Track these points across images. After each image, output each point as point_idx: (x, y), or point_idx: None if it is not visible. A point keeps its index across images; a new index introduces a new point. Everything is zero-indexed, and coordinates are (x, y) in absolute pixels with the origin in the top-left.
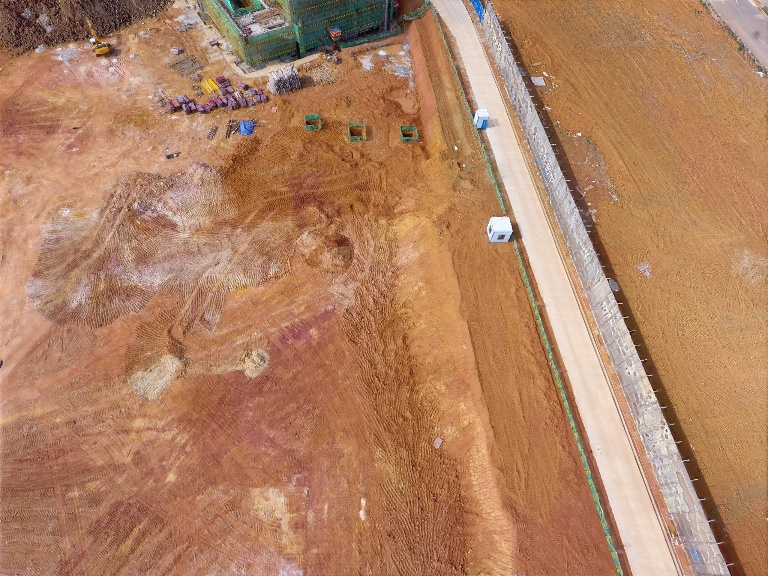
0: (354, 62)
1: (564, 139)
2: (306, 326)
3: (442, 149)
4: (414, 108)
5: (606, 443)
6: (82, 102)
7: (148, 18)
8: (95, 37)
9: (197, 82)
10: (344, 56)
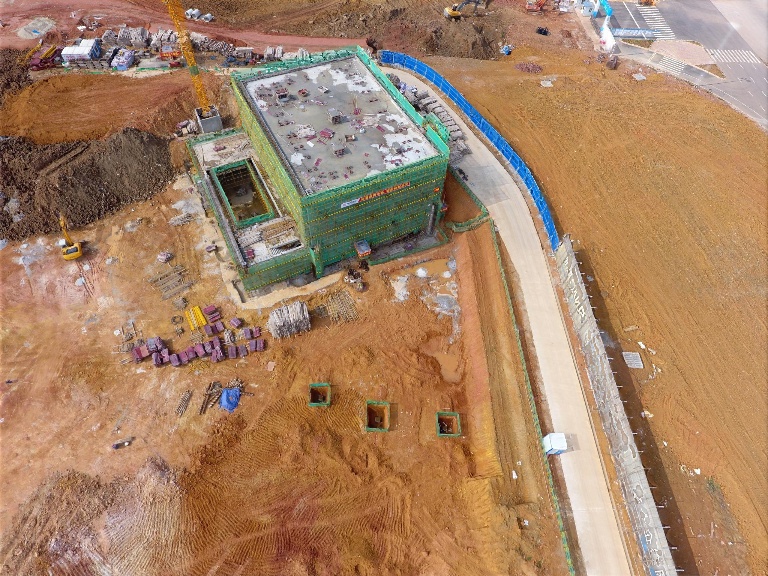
0: (384, 289)
1: (675, 479)
2: None
3: (494, 469)
4: (458, 372)
5: None
6: (29, 336)
7: (141, 202)
8: (66, 238)
9: (180, 310)
10: (372, 279)
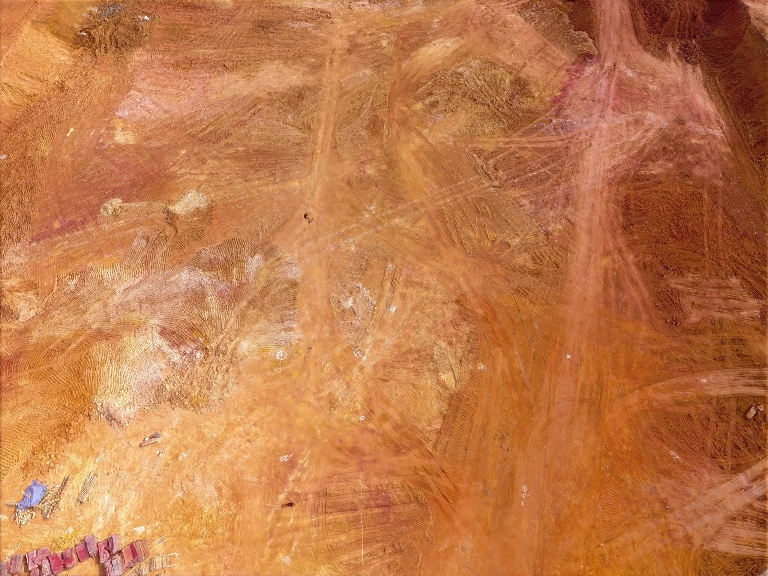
0: None
1: None
2: (61, 230)
3: None
4: None
5: None
6: (288, 573)
7: None
8: None
9: None
10: None
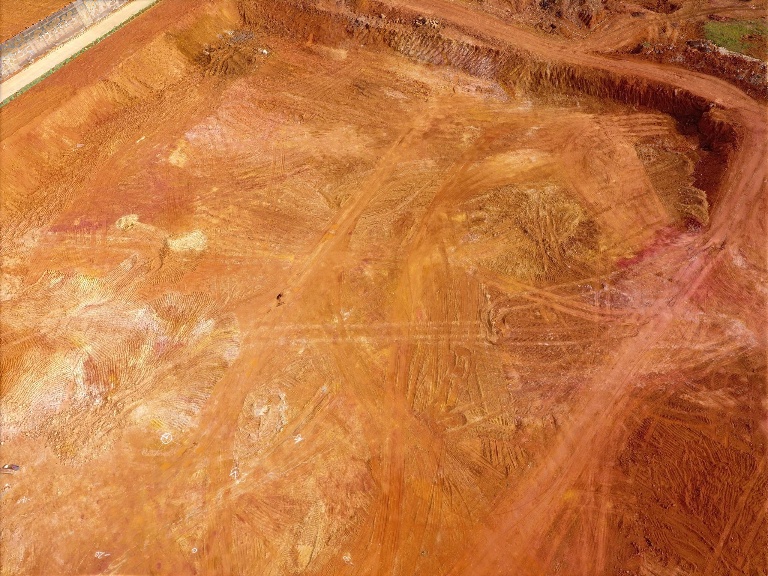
0: None
1: None
2: (77, 228)
3: None
4: None
5: (6, 91)
6: None
7: None
8: None
9: None
10: None
